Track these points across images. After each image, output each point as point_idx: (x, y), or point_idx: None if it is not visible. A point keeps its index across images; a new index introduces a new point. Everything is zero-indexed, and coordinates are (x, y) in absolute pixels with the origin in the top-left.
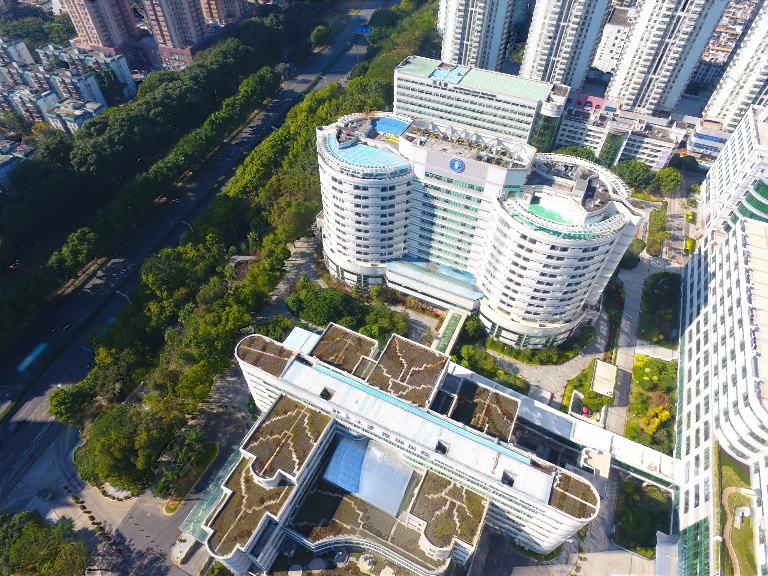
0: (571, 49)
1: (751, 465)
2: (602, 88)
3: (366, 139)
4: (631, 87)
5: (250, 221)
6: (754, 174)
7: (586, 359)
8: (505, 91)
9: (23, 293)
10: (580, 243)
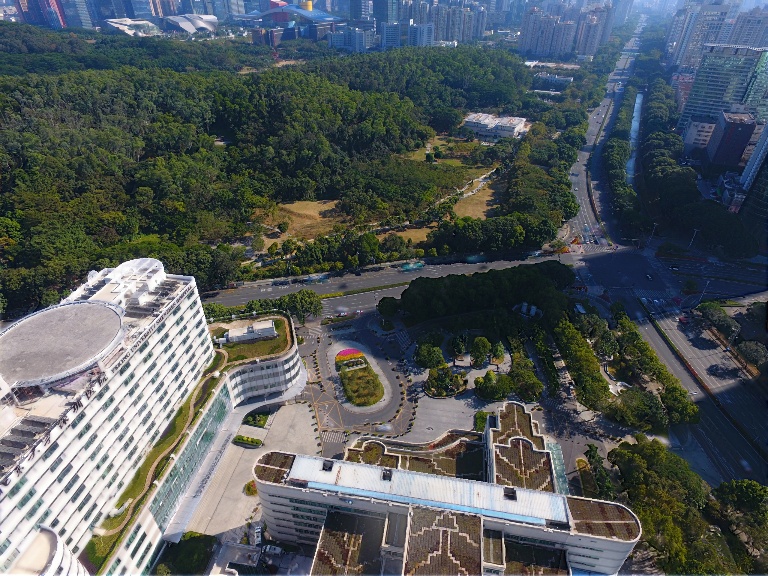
0: None
1: None
2: None
3: None
4: None
5: None
6: None
7: None
8: None
9: None
10: None
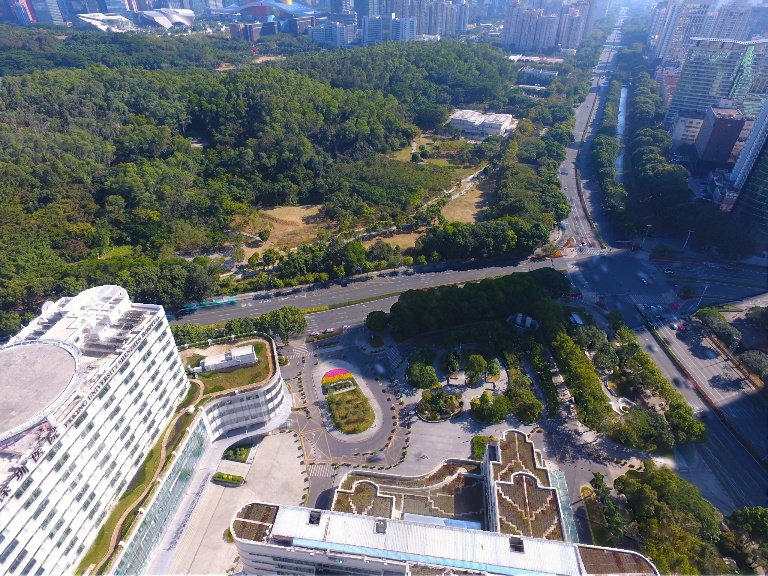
0: None
1: None
2: None
3: None
4: None
5: None
6: None
7: None
8: None
9: None
10: None
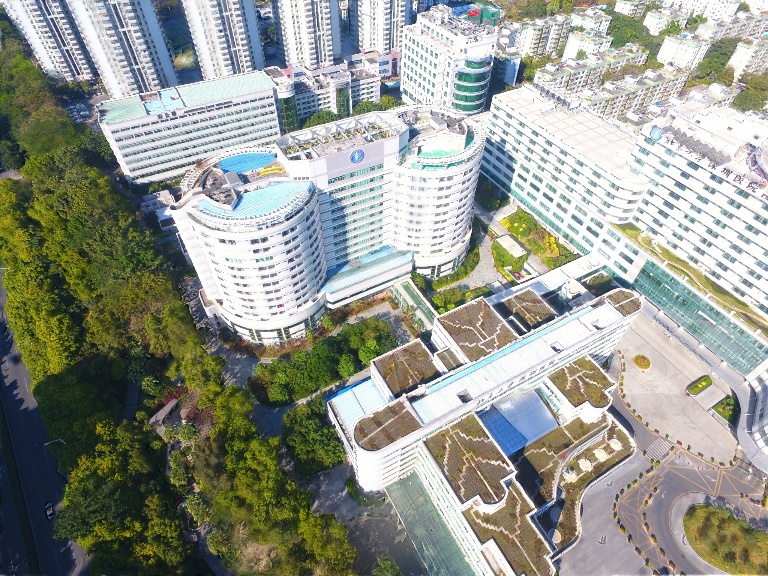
0: (245, 35)
1: (631, 221)
2: (275, 61)
3: (245, 186)
4: (308, 49)
5: (127, 373)
6: (454, 70)
7: (485, 246)
8: (235, 93)
9: None
10: (478, 159)
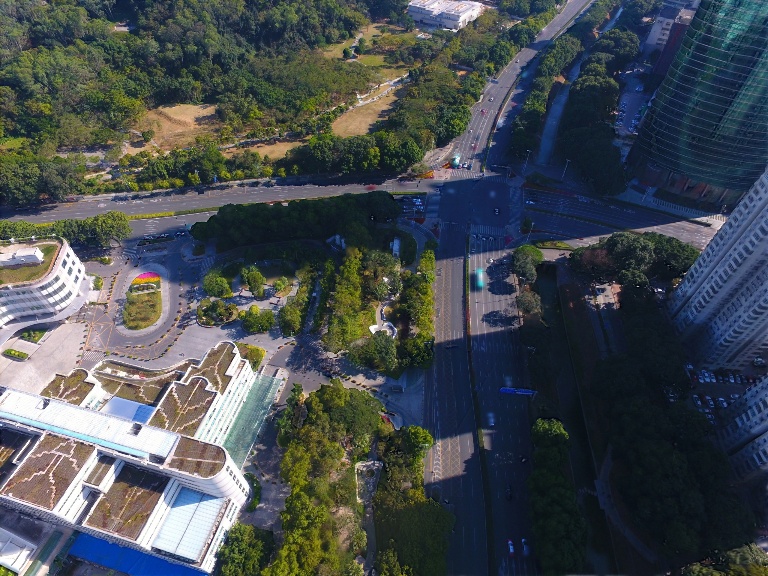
0: None
1: None
2: None
3: None
4: None
5: None
6: None
7: None
8: None
9: (553, 536)
10: None
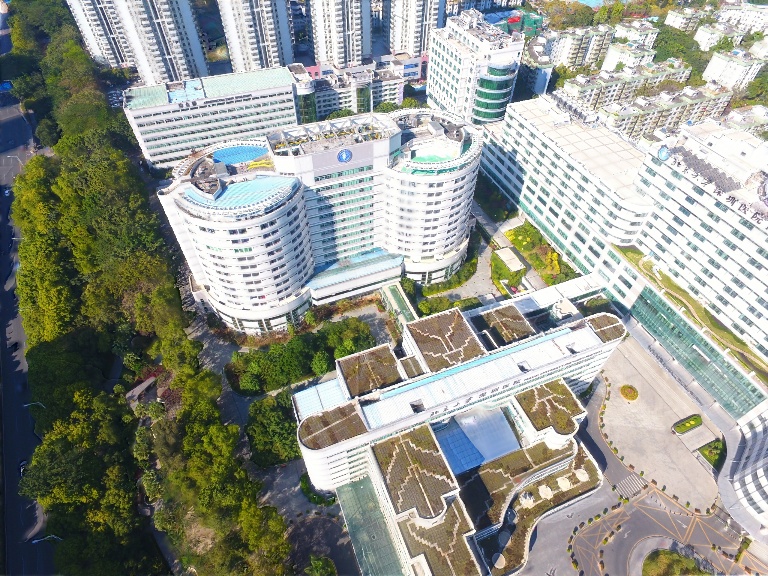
0: (274, 31)
1: (635, 243)
2: (306, 58)
3: (231, 177)
4: (337, 47)
5: (111, 347)
6: (476, 76)
7: (484, 257)
8: (255, 87)
9: None
10: (472, 167)
